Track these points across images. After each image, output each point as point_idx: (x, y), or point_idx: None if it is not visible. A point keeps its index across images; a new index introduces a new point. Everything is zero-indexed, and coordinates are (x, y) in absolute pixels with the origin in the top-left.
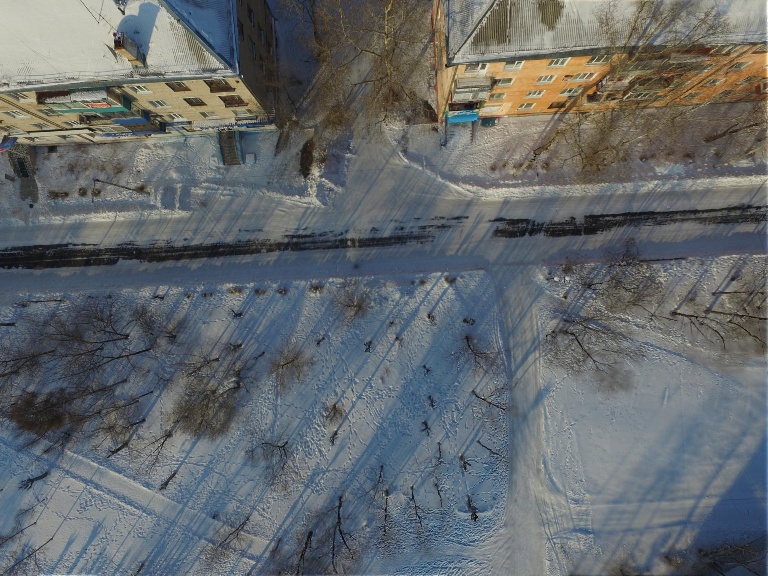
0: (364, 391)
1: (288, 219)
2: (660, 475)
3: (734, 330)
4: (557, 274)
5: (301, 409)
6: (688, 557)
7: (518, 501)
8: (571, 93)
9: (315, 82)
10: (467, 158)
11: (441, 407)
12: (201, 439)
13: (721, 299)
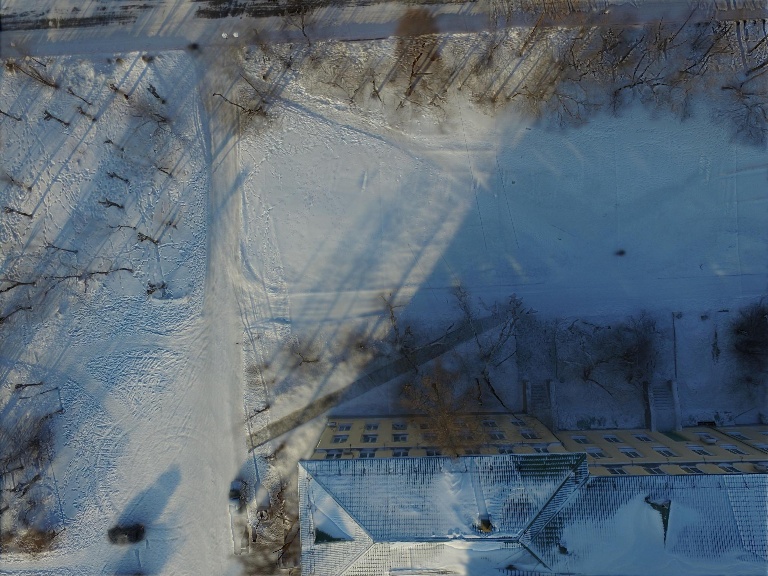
0: (60, 173)
1: None
2: (358, 262)
3: (435, 112)
4: (257, 54)
5: None
6: (385, 347)
7: (216, 290)
8: None
9: None
10: None
11: (138, 191)
12: None
13: (422, 80)
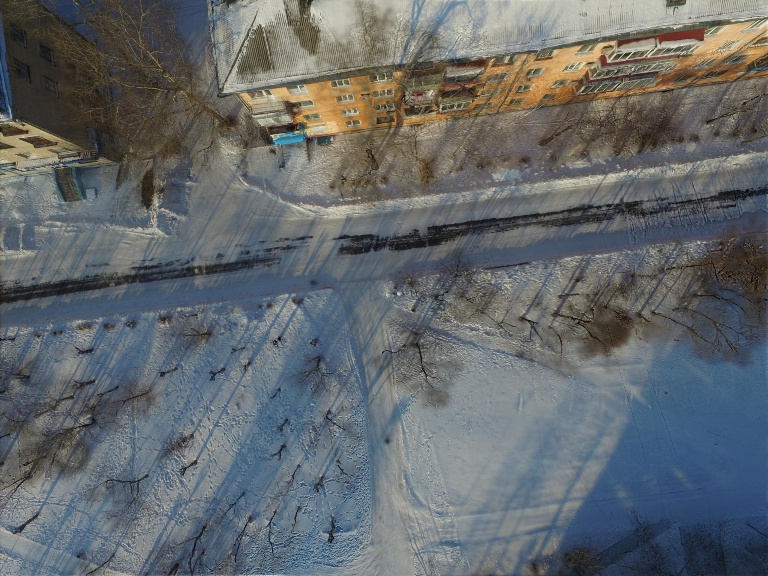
0: (220, 418)
1: (133, 251)
2: (521, 482)
3: (583, 331)
4: (404, 288)
5: (159, 441)
6: (555, 562)
7: (383, 518)
8: (388, 108)
9: (150, 113)
10: (306, 178)
11: (298, 429)
12: (61, 478)
13: (568, 301)
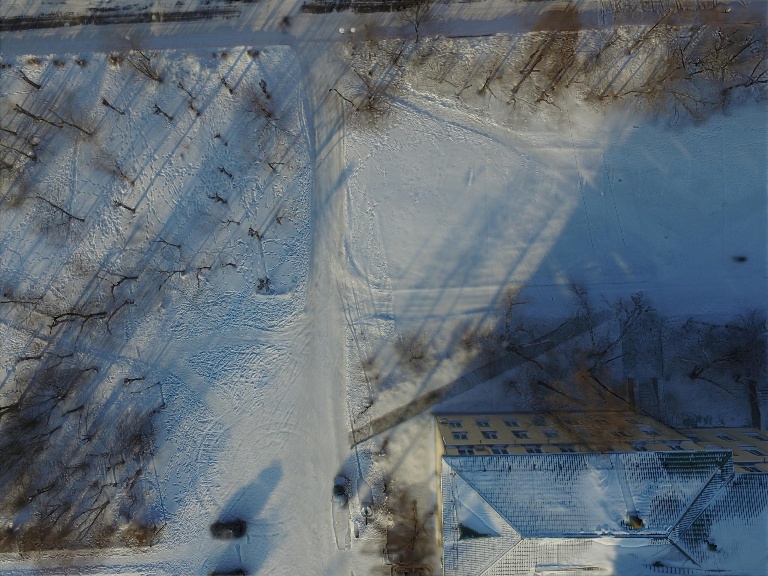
0: (163, 168)
1: None
2: (463, 259)
3: (542, 110)
4: (363, 50)
5: (99, 186)
6: (489, 344)
7: (319, 285)
8: None
9: None
10: None
11: (241, 186)
12: None
13: (529, 78)
